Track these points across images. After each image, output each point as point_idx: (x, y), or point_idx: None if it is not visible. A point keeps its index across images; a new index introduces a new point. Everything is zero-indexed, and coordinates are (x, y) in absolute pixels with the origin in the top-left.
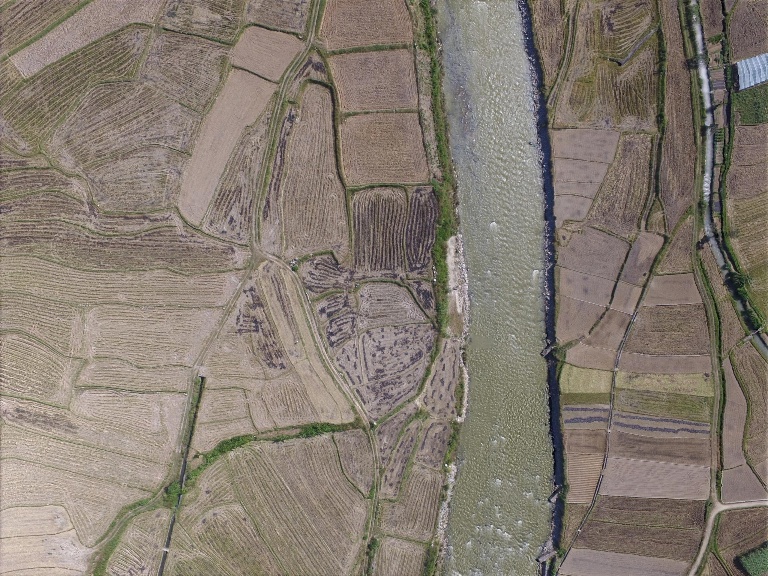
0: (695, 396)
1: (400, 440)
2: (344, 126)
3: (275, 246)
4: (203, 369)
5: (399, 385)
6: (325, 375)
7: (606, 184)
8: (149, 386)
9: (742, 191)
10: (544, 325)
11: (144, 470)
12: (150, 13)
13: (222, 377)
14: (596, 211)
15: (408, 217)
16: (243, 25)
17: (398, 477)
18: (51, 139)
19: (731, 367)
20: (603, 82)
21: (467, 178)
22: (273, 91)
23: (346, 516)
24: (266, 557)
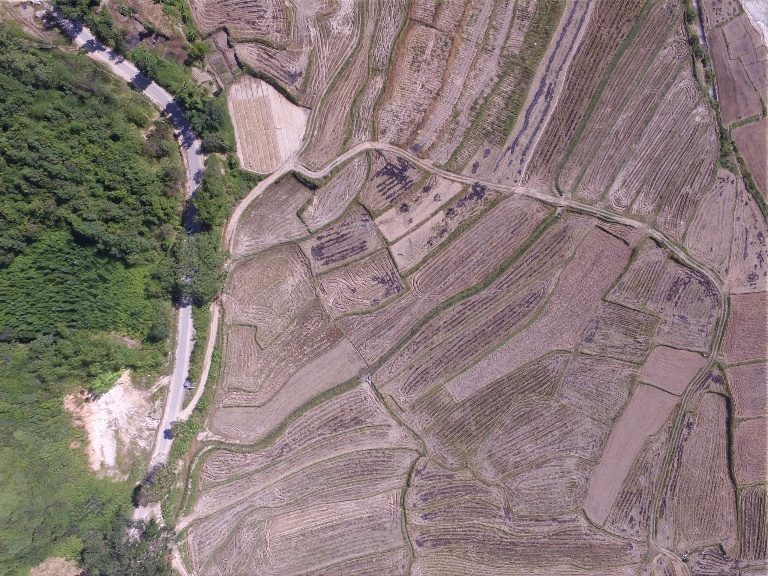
0: None
1: None
2: (737, 430)
3: (669, 541)
4: None
5: None
6: None
7: None
8: None
9: None
10: None
11: None
12: (570, 340)
13: None
14: None
15: None
16: (653, 347)
17: None
18: (475, 454)
19: None
20: None
21: None
22: (675, 403)
23: None
24: None
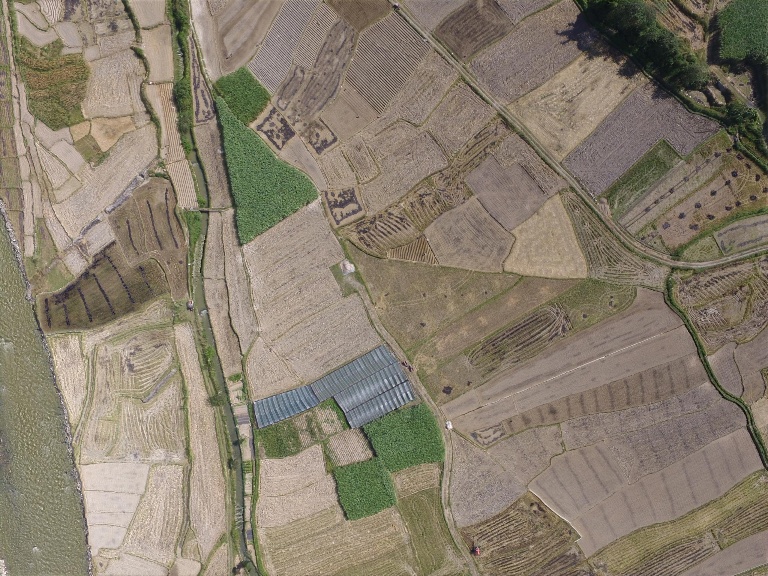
0: None
1: None
2: None
3: None
4: None
5: None
6: None
7: (140, 513)
8: None
9: (274, 520)
10: None
11: None
12: None
13: None
14: (131, 539)
15: None
16: None
17: None
18: None
19: None
20: (129, 418)
21: (4, 508)
22: None
23: None
24: None
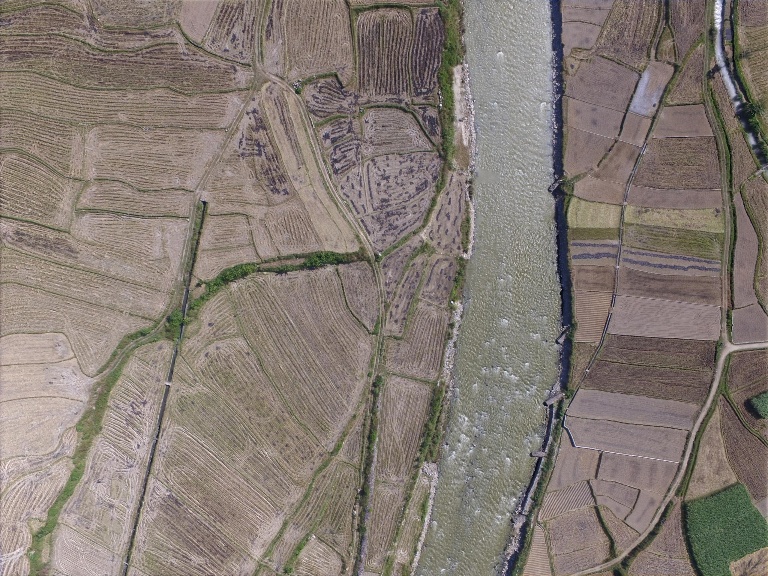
0: (705, 232)
1: (405, 275)
2: None
3: (278, 67)
4: (205, 194)
5: (404, 216)
6: (329, 202)
7: (615, 11)
8: (151, 210)
9: (754, 18)
10: (552, 160)
11: (146, 298)
12: None
13: (225, 202)
14: (605, 39)
15: (413, 39)
16: None
17: (403, 313)
18: None
19: (742, 202)
20: None
21: (473, 5)
22: None
23: (351, 352)
24: (270, 393)
